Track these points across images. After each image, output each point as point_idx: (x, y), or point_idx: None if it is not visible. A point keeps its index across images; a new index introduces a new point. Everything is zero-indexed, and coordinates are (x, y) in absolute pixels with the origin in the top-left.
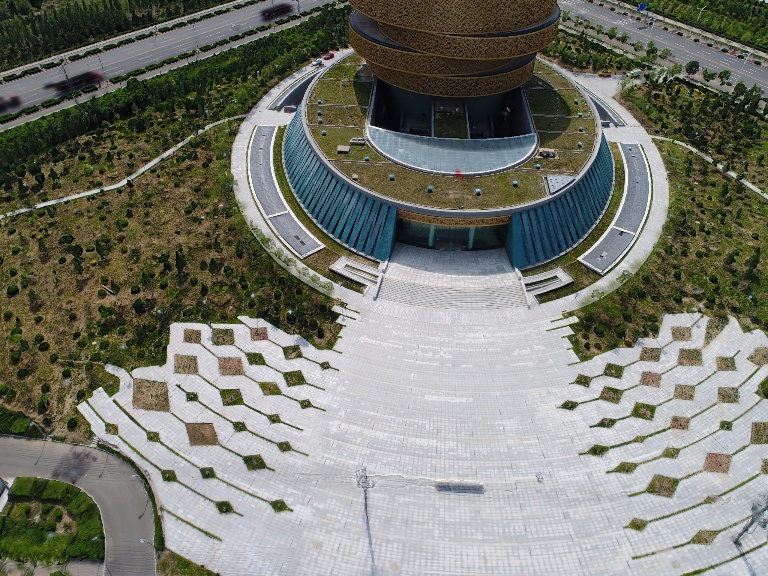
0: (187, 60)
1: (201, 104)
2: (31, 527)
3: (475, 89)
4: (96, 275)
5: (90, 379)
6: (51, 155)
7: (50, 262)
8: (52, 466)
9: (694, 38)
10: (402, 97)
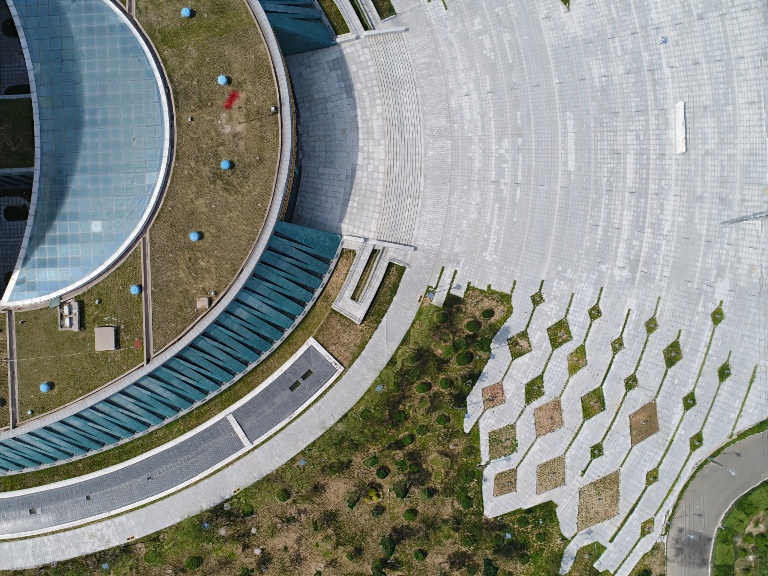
0: None
1: None
2: (765, 558)
3: None
4: None
5: None
6: None
7: None
8: (694, 572)
9: None
10: None
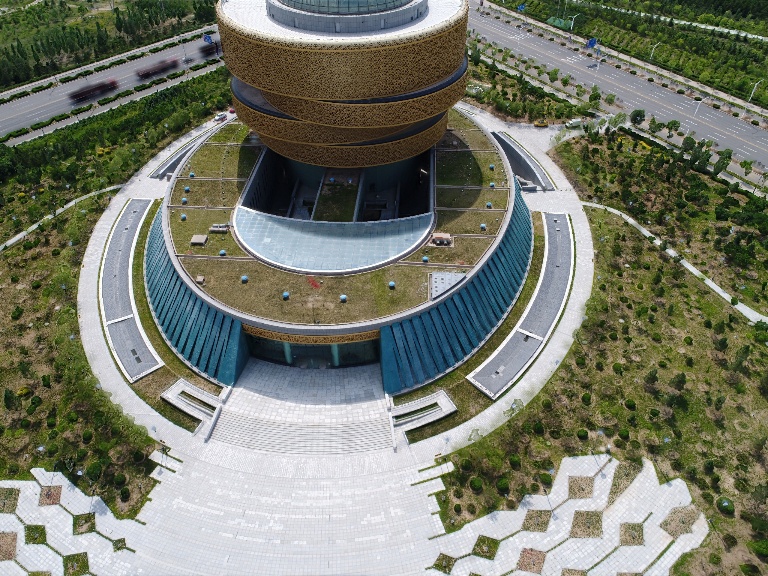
0: (78, 117)
1: (71, 174)
2: None
3: (368, 158)
4: None
5: None
6: None
7: None
8: None
9: (648, 77)
10: (296, 163)
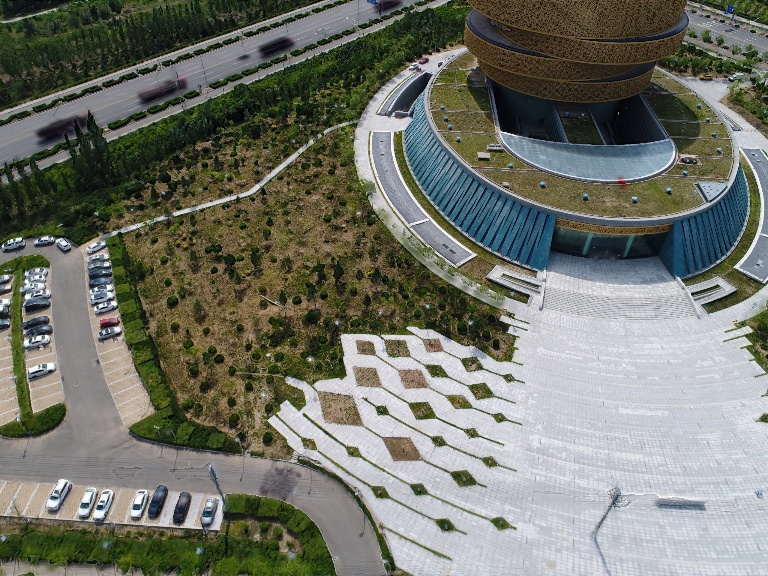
0: (282, 65)
1: (312, 110)
2: (255, 546)
3: (603, 94)
4: (253, 285)
5: (273, 392)
6: (173, 162)
7: (201, 272)
8: (258, 482)
9: None
10: (518, 102)
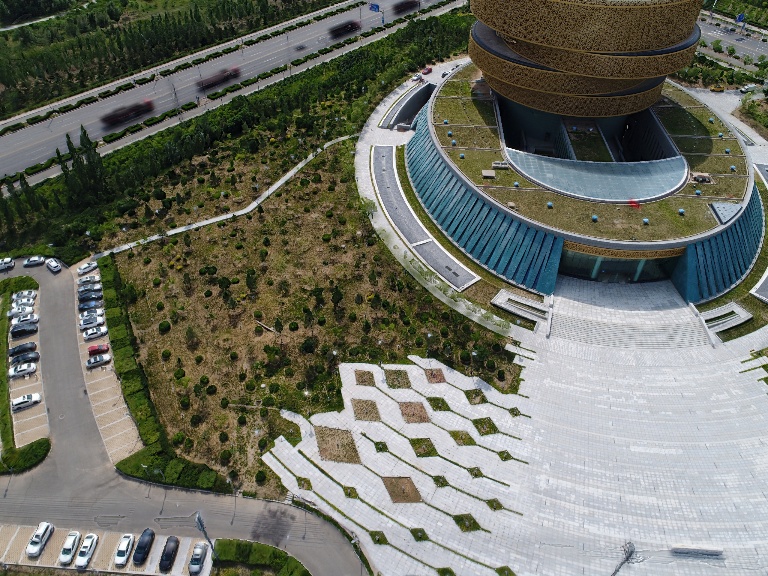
0: (282, 75)
1: (312, 123)
2: None
3: (612, 109)
4: (248, 310)
5: (268, 426)
6: (168, 177)
7: (195, 295)
8: (250, 526)
9: None
10: (524, 116)
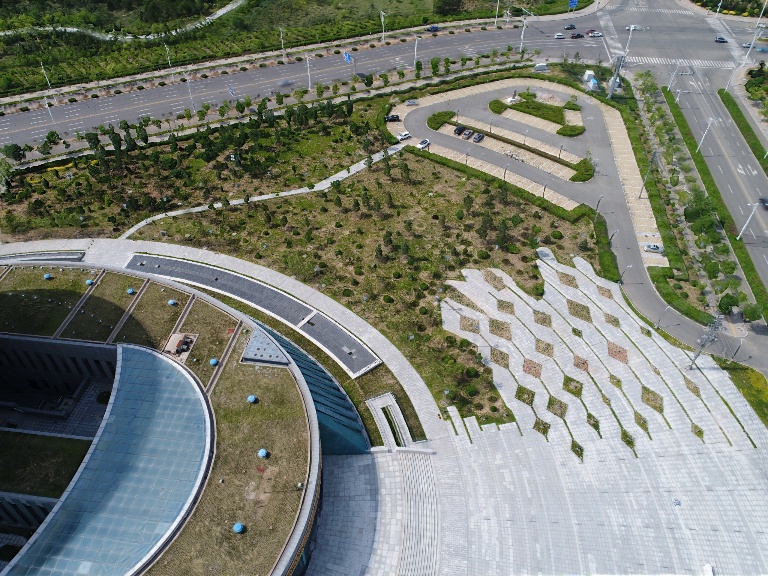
0: None
1: None
2: None
3: None
4: None
5: None
6: None
7: None
8: None
9: None
10: None
